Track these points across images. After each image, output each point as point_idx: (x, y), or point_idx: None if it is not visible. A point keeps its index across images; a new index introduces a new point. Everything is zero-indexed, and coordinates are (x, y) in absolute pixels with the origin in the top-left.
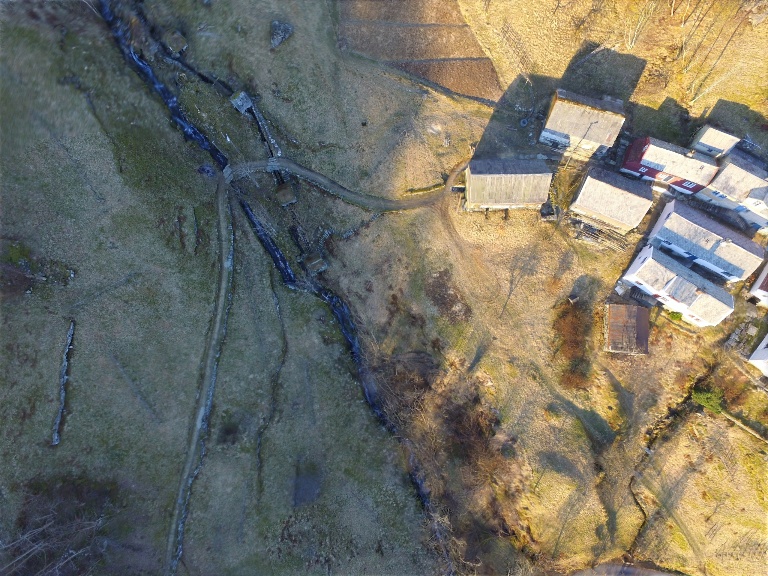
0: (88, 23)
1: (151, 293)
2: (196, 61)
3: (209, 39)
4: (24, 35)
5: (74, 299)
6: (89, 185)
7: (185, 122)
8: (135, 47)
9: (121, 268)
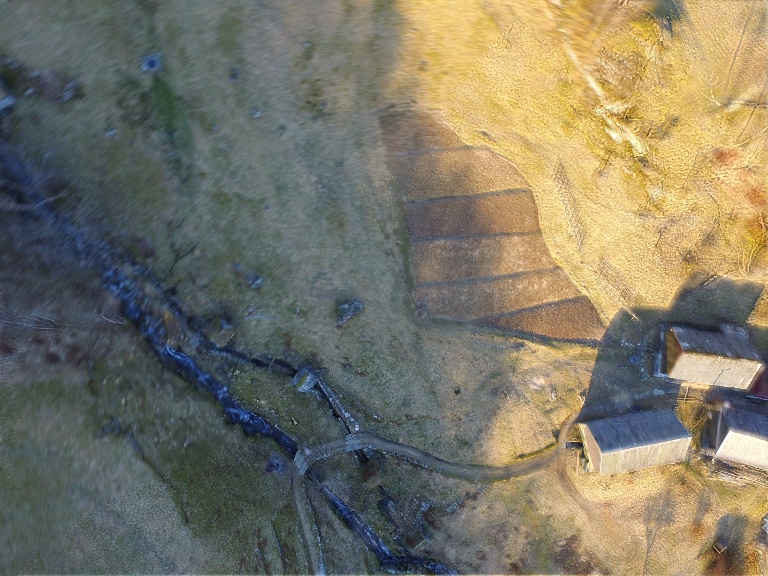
0: (114, 337)
1: None
2: (247, 347)
3: (260, 322)
4: (44, 392)
5: None
6: (152, 551)
7: (240, 409)
8: (172, 346)
9: None
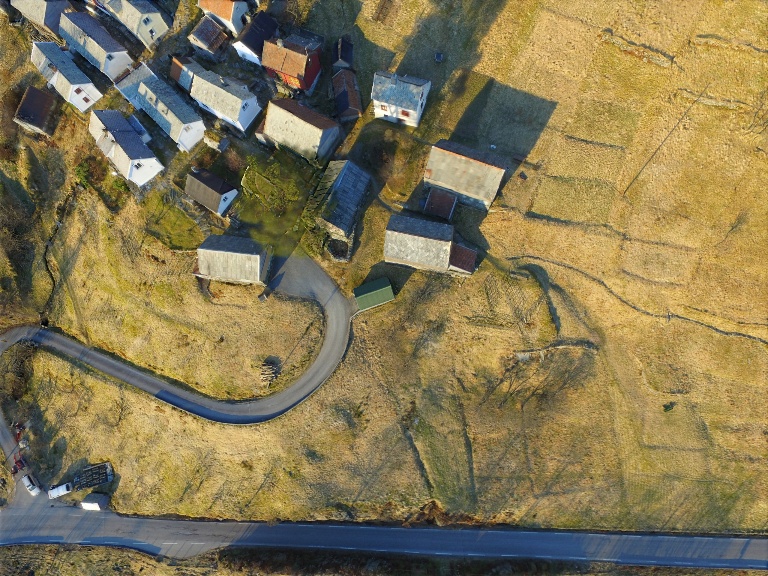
0: None
1: None
2: None
3: None
4: None
5: None
6: None
7: None
8: None
9: None
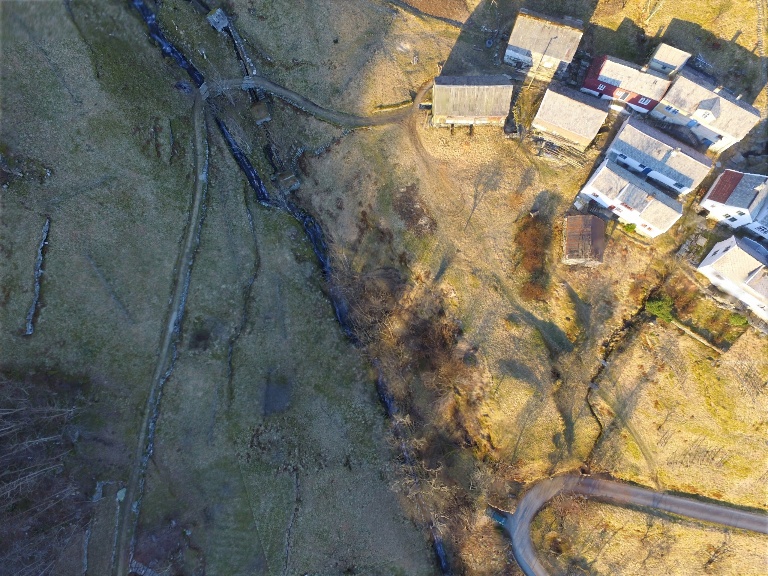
0: None
1: (126, 197)
2: None
3: None
4: None
5: (50, 197)
6: (66, 88)
7: (163, 40)
8: None
9: (97, 171)
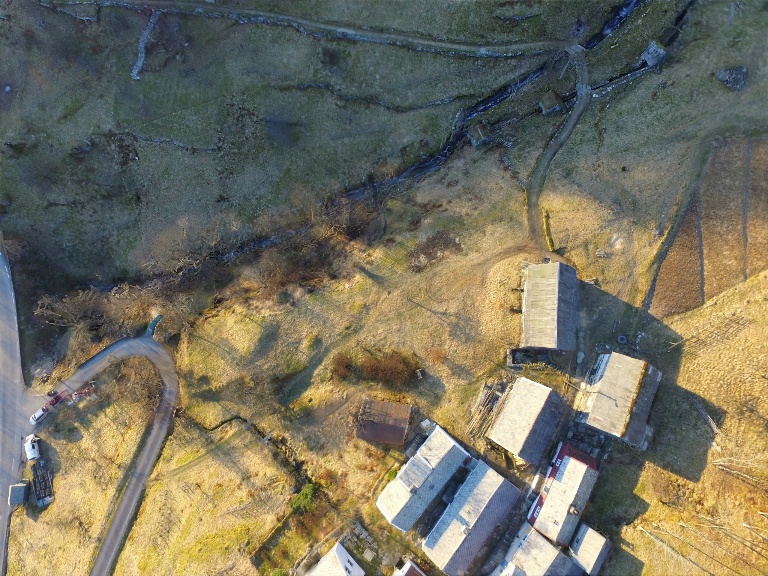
0: None
1: None
2: (701, 6)
3: (726, 15)
4: None
5: None
6: None
7: (633, 7)
8: None
9: None
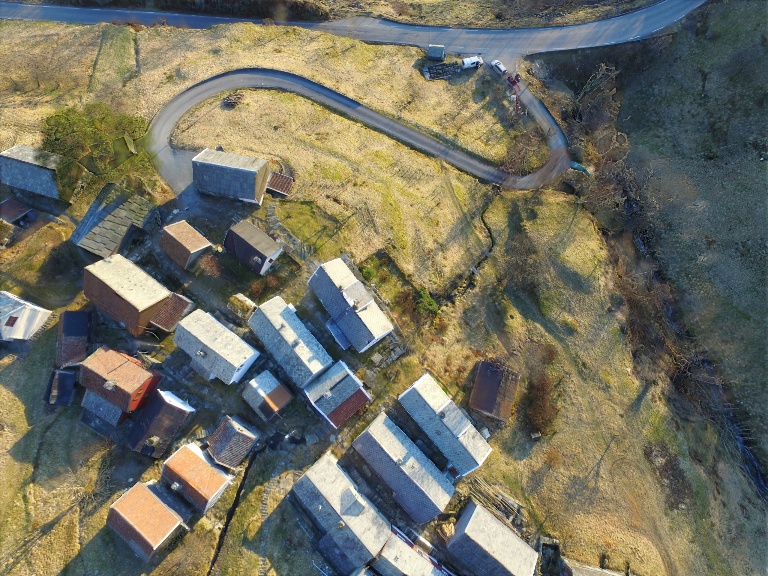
0: None
1: None
2: None
3: None
4: None
5: None
6: None
7: None
8: None
9: None
